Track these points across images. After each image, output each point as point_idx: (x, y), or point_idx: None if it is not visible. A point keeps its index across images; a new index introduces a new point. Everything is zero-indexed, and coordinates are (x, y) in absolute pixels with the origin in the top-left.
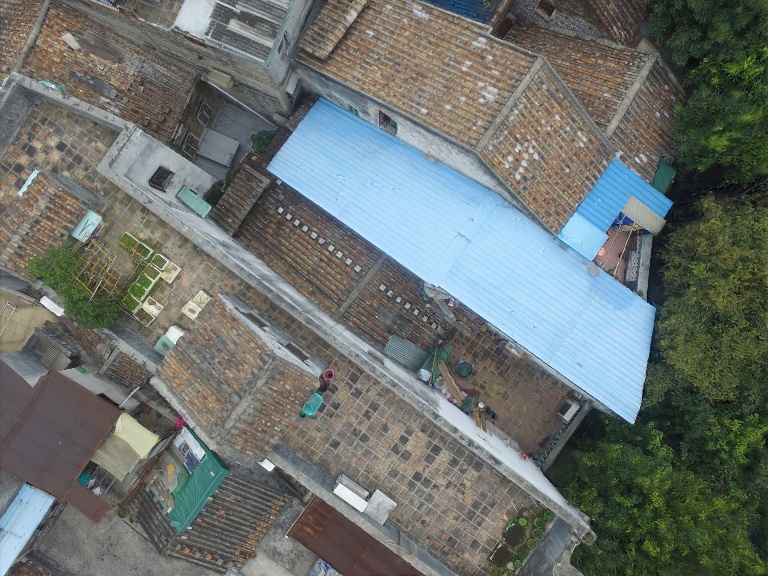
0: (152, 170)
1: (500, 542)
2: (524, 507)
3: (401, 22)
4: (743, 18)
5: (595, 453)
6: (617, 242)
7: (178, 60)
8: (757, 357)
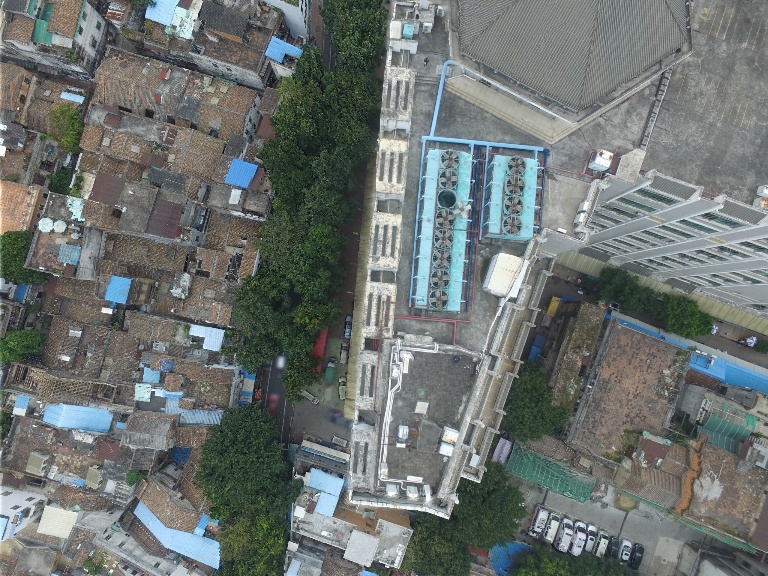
0: (103, 532)
1: None
2: None
3: None
4: None
5: None
6: None
7: None
8: (247, 549)
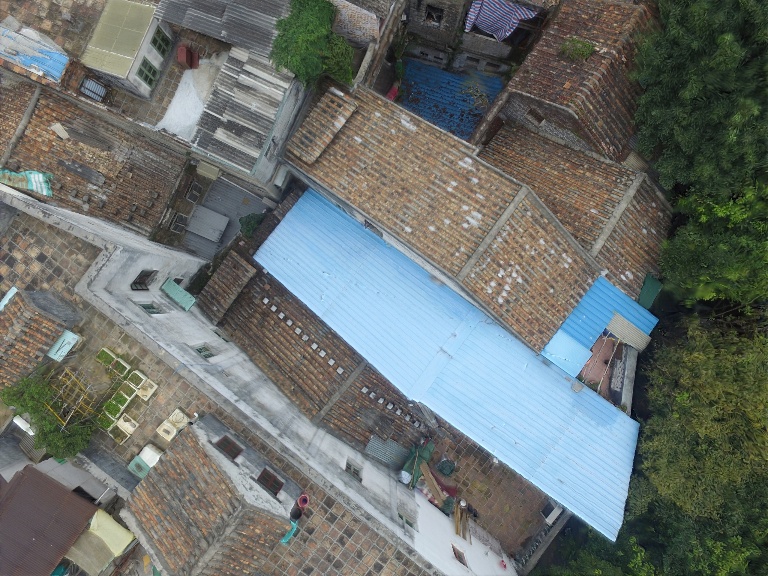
0: (134, 275)
1: None
2: None
3: (389, 132)
4: (729, 159)
5: (576, 563)
6: (603, 348)
7: (167, 148)
8: None
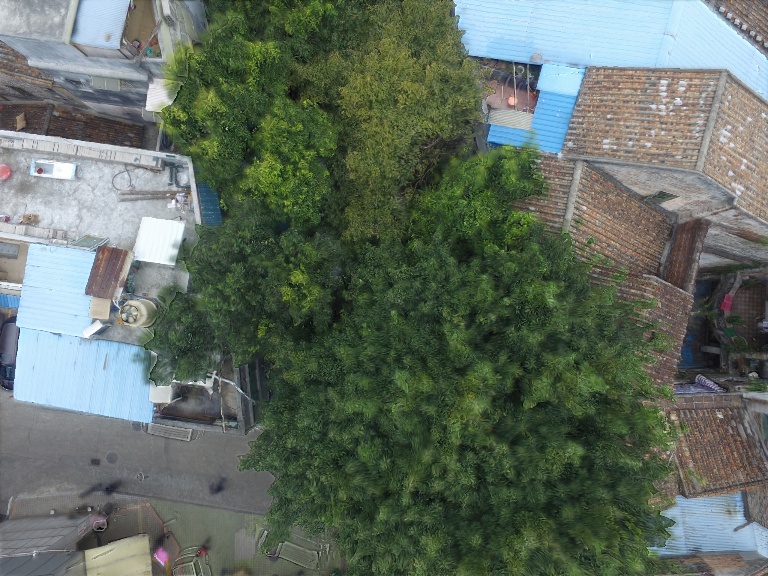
0: None
1: None
2: None
3: None
4: None
5: None
6: None
7: None
8: None
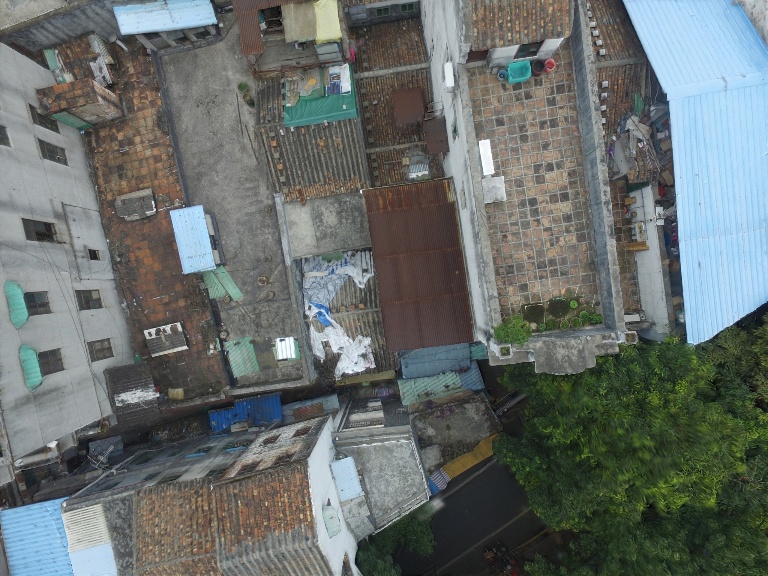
0: None
1: (543, 303)
2: (583, 297)
3: None
4: None
5: None
6: None
7: None
8: None
